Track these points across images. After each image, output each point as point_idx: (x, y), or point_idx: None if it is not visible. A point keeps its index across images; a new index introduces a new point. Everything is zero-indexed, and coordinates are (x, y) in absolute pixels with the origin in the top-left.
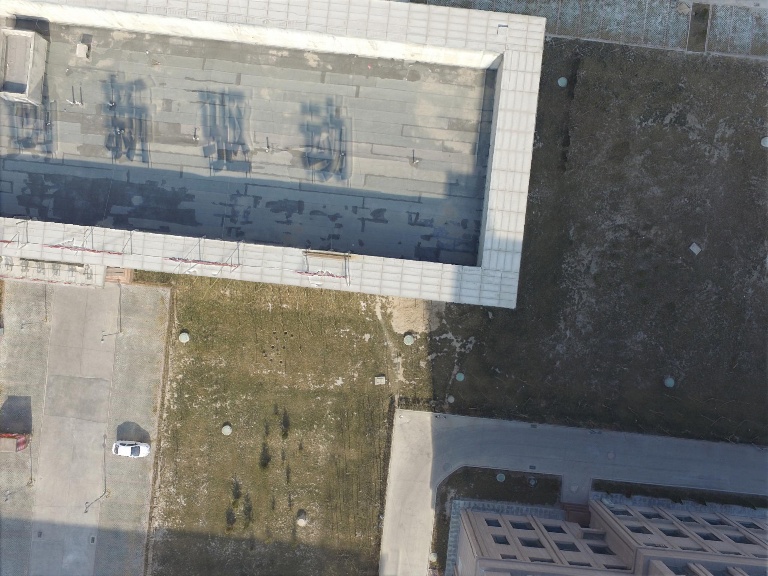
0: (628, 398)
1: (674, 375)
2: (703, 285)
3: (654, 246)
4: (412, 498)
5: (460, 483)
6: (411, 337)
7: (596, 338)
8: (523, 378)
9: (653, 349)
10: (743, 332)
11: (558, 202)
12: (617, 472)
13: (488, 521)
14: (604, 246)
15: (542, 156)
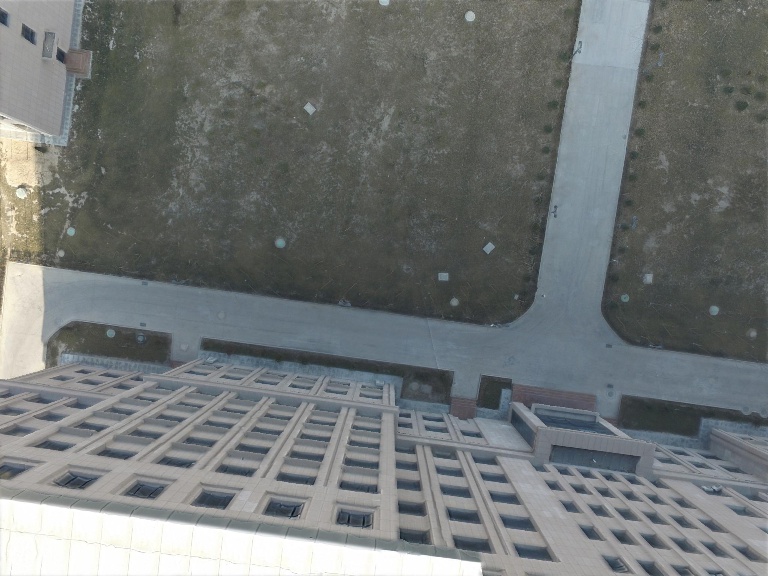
0: (239, 258)
1: (286, 236)
2: (318, 146)
3: (268, 105)
4: (24, 351)
5: (71, 338)
6: (22, 190)
7: (209, 197)
8: (135, 235)
9: (266, 210)
10: (357, 195)
11: (173, 58)
12: (227, 332)
13: (85, 372)
14: (218, 104)
15: (157, 10)
